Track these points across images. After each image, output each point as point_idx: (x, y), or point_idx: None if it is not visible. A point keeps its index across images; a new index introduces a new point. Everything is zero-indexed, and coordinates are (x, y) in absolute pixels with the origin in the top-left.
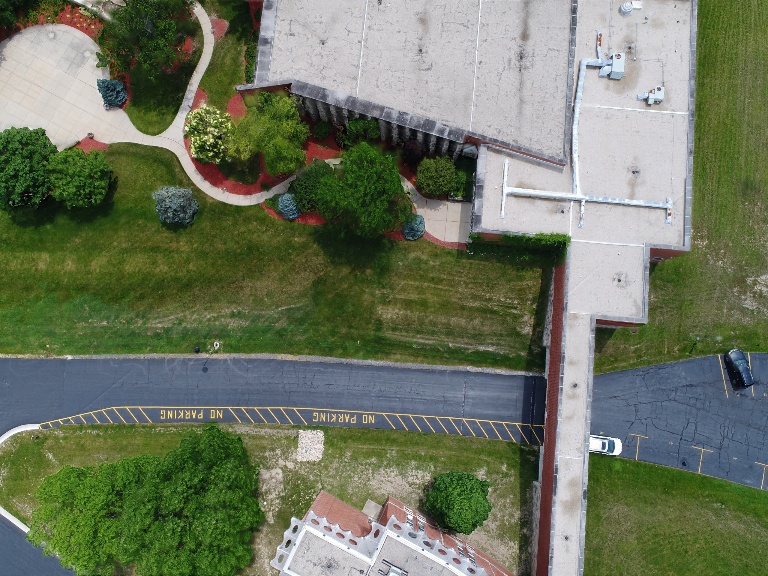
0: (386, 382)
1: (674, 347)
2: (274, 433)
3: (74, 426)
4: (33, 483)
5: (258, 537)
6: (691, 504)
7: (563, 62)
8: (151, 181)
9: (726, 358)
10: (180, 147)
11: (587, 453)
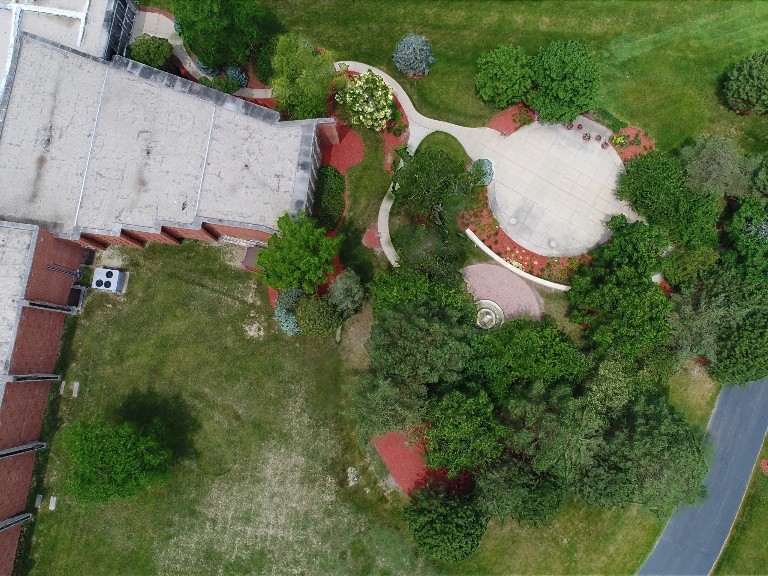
0: None
1: None
2: None
3: None
4: None
5: None
6: None
7: (8, 132)
8: (442, 89)
9: None
10: (413, 118)
11: None
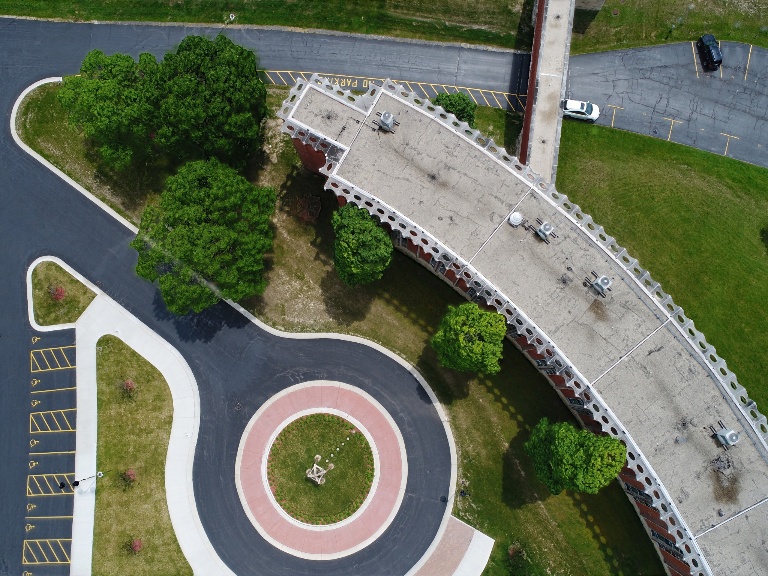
0: (386, 53)
1: (651, 33)
2: (281, 93)
3: None
4: (57, 126)
5: (262, 175)
6: (660, 164)
7: None
8: None
9: (698, 43)
10: None
11: (566, 70)
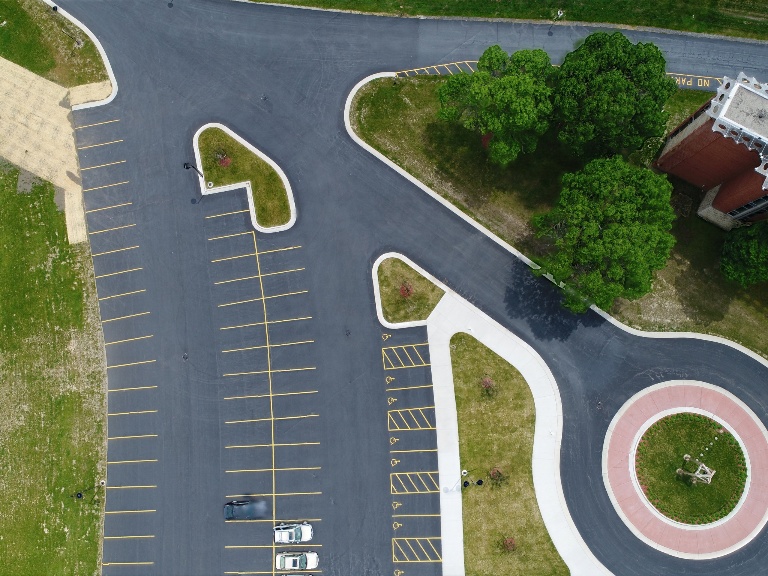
0: (719, 52)
1: None
2: None
3: (429, 76)
4: (392, 122)
5: None
6: None
7: None
8: None
9: None
10: None
11: None
